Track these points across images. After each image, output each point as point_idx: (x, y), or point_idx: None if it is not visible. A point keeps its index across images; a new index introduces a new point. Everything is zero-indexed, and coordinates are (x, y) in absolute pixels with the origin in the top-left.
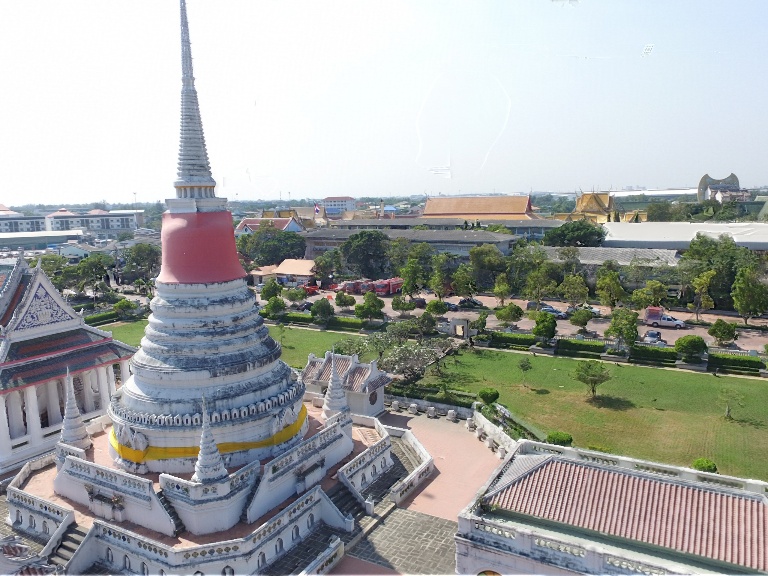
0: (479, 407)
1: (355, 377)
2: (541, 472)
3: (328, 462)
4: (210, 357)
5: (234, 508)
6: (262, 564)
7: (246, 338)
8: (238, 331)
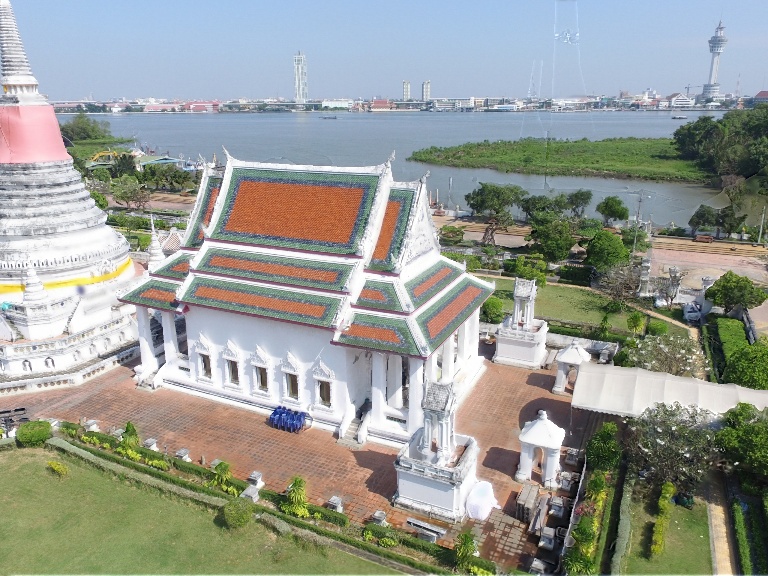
0: None
1: None
2: None
3: None
4: None
5: None
6: None
7: None
8: None
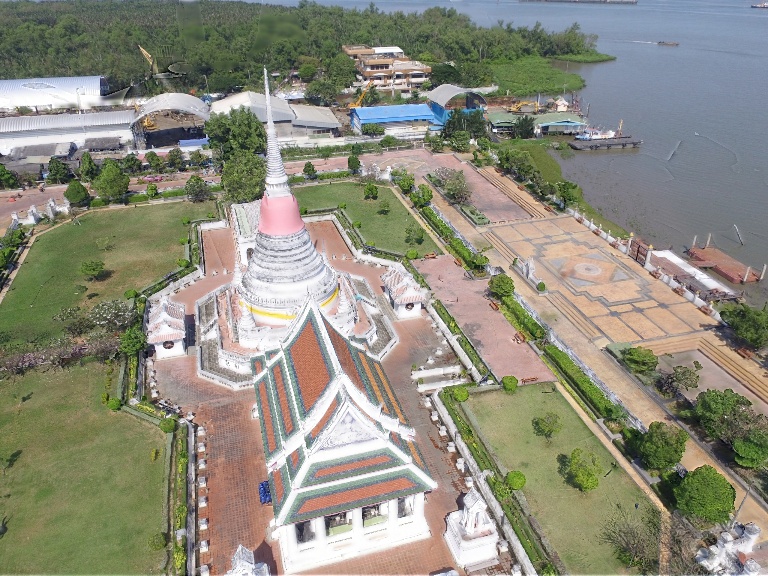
0: None
1: None
2: None
3: None
4: None
5: None
6: None
7: None
8: None
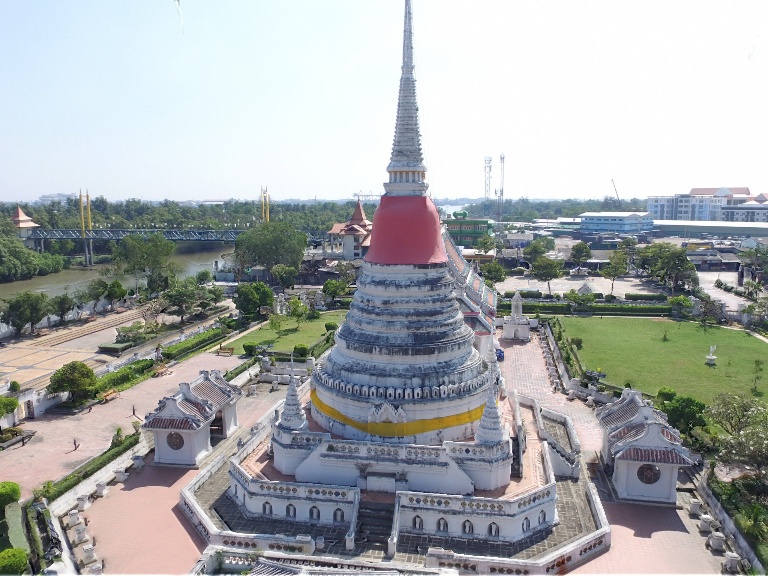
0: (765, 574)
1: (628, 434)
2: (283, 575)
3: (420, 483)
4: (356, 331)
5: (293, 460)
6: (270, 513)
7: (390, 323)
8: (383, 314)
